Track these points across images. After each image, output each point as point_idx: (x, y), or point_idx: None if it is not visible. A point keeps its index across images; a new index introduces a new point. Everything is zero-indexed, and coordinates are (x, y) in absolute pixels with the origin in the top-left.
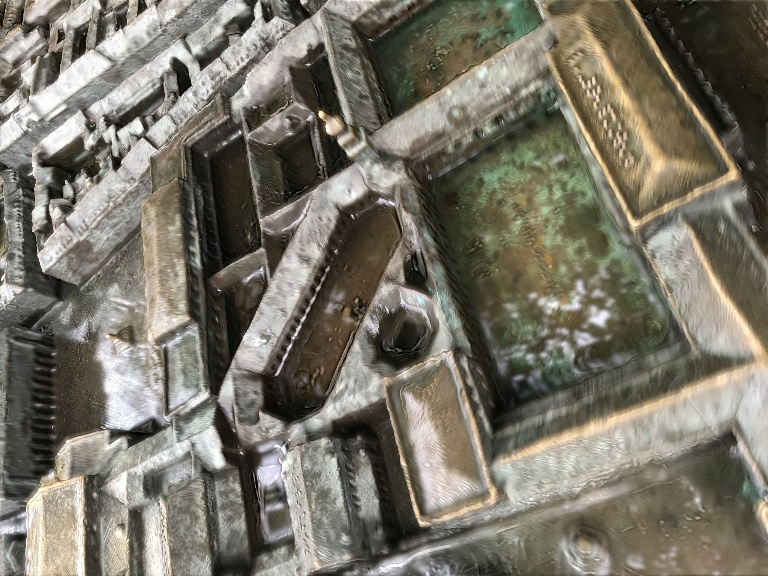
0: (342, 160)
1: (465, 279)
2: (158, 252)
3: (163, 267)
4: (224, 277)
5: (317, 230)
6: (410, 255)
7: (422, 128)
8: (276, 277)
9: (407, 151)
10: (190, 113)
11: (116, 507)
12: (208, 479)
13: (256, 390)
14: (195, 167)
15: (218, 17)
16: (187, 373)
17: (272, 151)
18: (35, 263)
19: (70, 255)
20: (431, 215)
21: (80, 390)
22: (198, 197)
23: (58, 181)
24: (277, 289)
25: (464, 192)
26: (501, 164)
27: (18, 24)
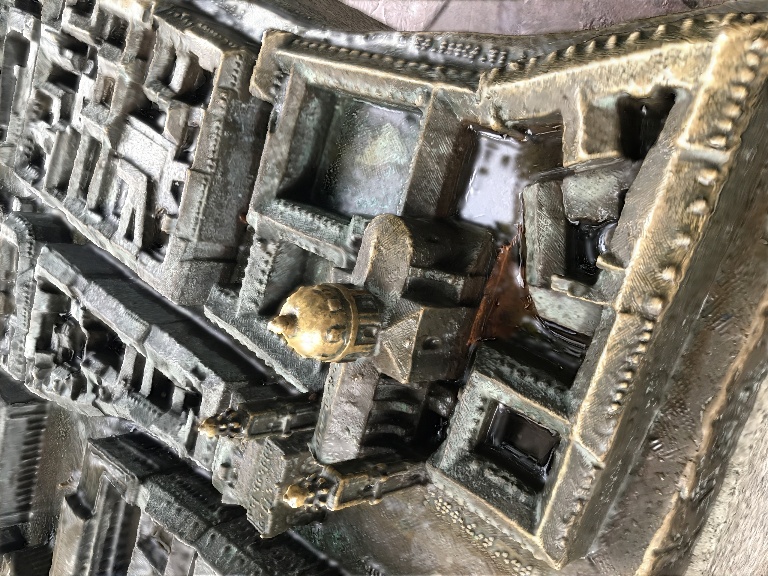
0: None
1: None
2: (55, 571)
3: None
4: None
5: None
6: None
7: None
8: None
9: None
10: (130, 419)
11: None
12: None
13: None
14: (111, 493)
15: (169, 365)
16: None
17: None
18: None
19: None
20: None
21: (53, 469)
22: (105, 523)
23: (53, 310)
24: None
25: None
26: None
27: (54, 33)
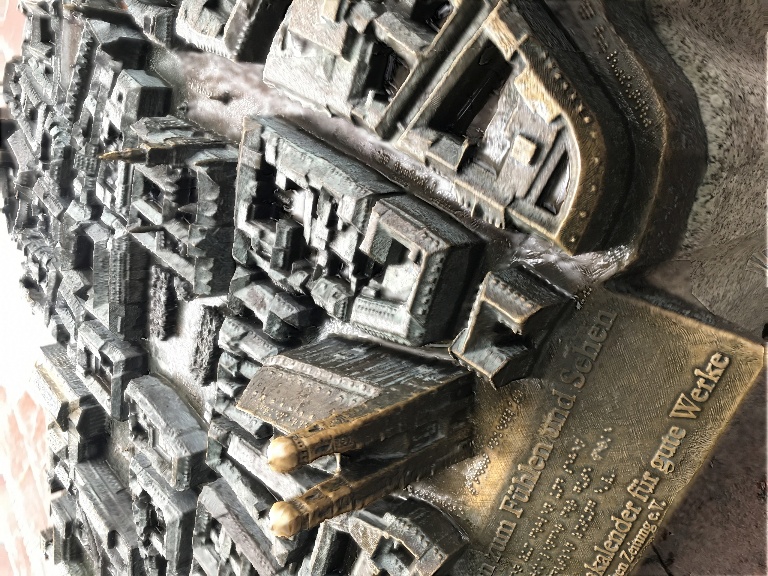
0: None
1: None
2: None
3: None
4: None
5: None
6: None
7: None
8: None
9: None
10: None
11: None
12: None
13: None
14: None
15: None
16: None
17: None
18: None
19: None
20: None
21: None
22: None
23: None
24: None
25: None
26: None
27: None
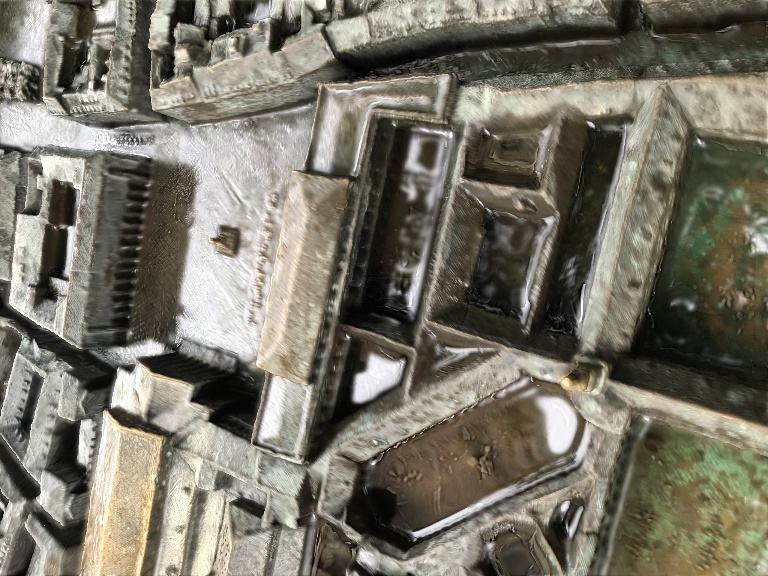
0: (558, 306)
1: (610, 539)
2: (295, 279)
3: (296, 303)
4: (359, 333)
5: (485, 381)
6: (569, 503)
7: (678, 412)
8: (415, 404)
9: (641, 406)
10: (397, 32)
11: (186, 470)
12: (276, 530)
13: (348, 480)
14: (375, 147)
15: None
16: (286, 423)
17: (480, 212)
18: (144, 69)
19: (188, 108)
20: (619, 460)
21: (170, 252)
22: (364, 199)
23: None
24: (411, 414)
25: (673, 448)
26: (737, 459)
27: None
